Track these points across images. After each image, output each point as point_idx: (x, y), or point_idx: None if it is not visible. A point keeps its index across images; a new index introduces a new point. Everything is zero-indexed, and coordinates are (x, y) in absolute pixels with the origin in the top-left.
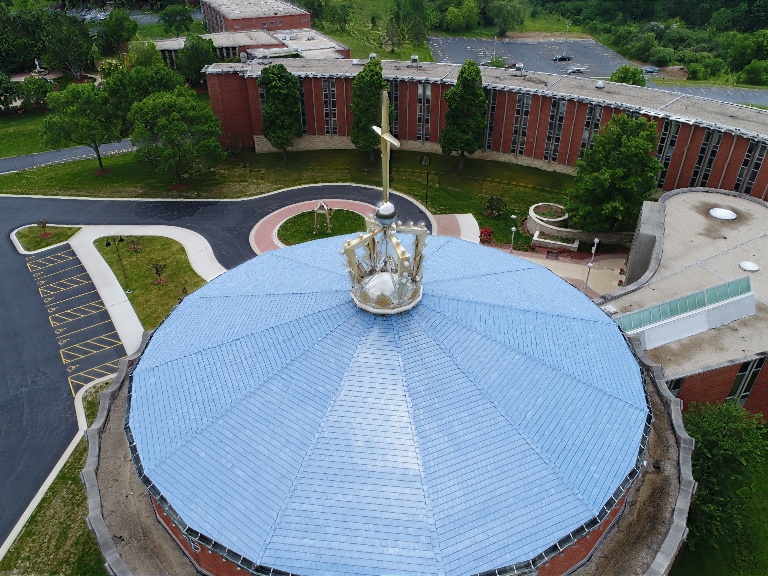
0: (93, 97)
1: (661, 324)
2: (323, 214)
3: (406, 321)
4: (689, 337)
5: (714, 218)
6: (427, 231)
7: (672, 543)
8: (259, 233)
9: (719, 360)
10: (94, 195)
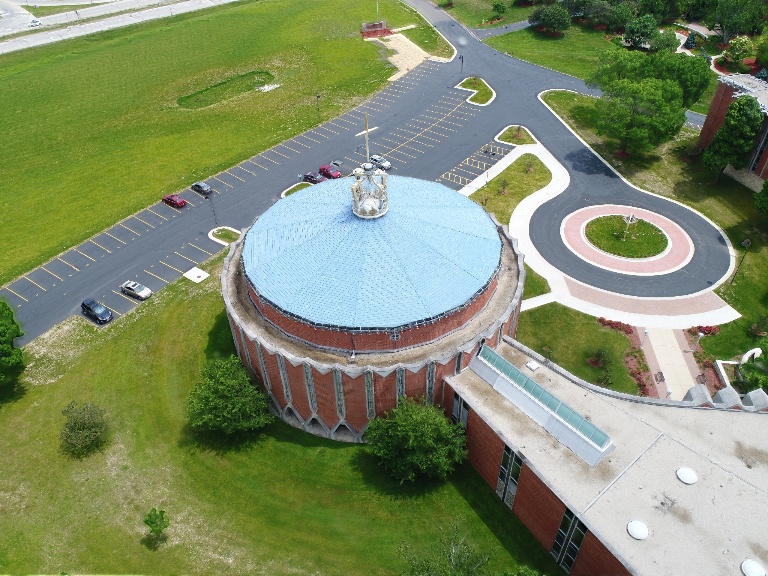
0: (624, 63)
1: (512, 384)
2: (648, 229)
3: (354, 220)
4: (524, 414)
5: None
6: (383, 190)
7: None
8: (593, 209)
9: (502, 429)
10: (576, 130)
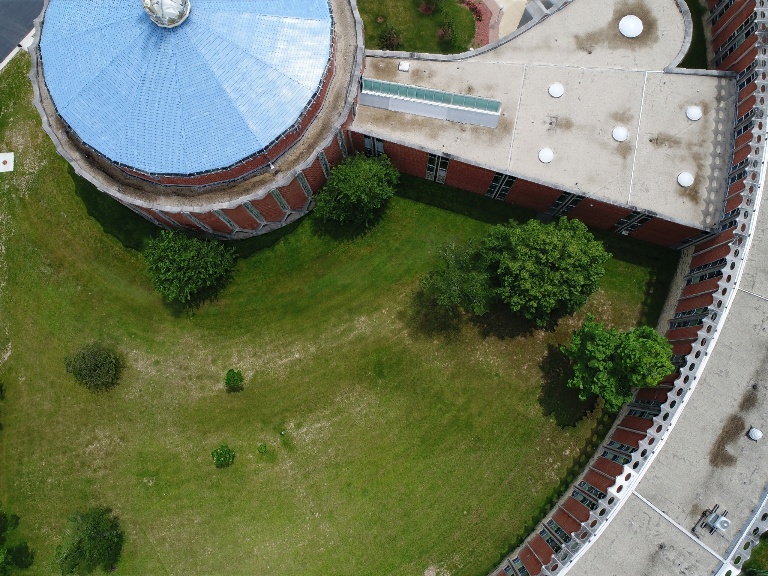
0: None
1: (405, 99)
2: None
3: (165, 34)
4: (426, 117)
5: (617, 26)
6: None
7: (236, 203)
8: None
9: (419, 142)
10: None
